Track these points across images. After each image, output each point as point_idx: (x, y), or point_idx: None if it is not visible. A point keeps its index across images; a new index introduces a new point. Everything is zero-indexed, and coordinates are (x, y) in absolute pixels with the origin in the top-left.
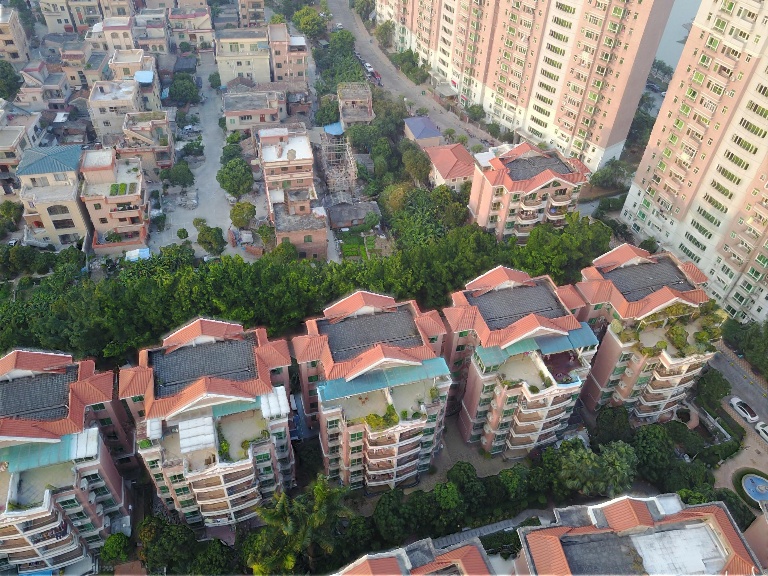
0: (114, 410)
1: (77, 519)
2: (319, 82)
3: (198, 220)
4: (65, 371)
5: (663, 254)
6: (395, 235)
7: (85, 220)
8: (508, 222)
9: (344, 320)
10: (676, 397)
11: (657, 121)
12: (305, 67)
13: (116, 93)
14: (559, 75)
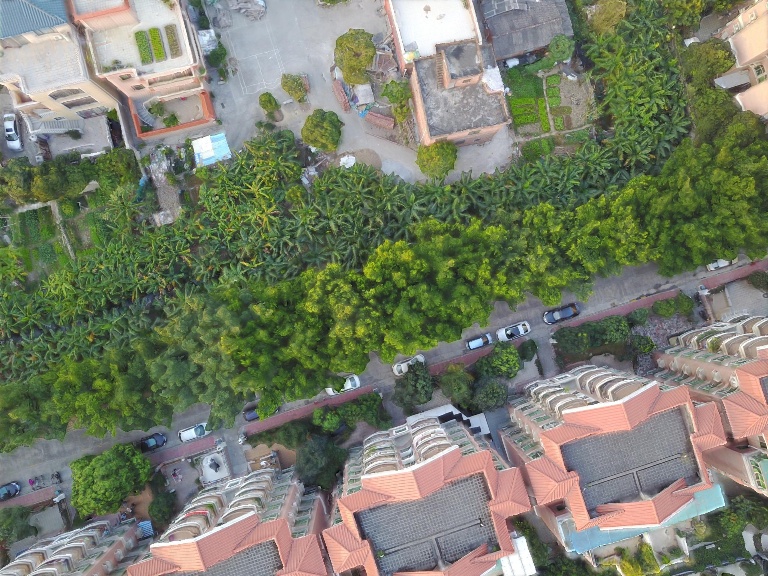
0: None
1: None
2: None
3: (290, 84)
4: None
5: None
6: (596, 84)
7: (110, 91)
8: None
9: None
10: None
11: None
12: None
13: None
14: None
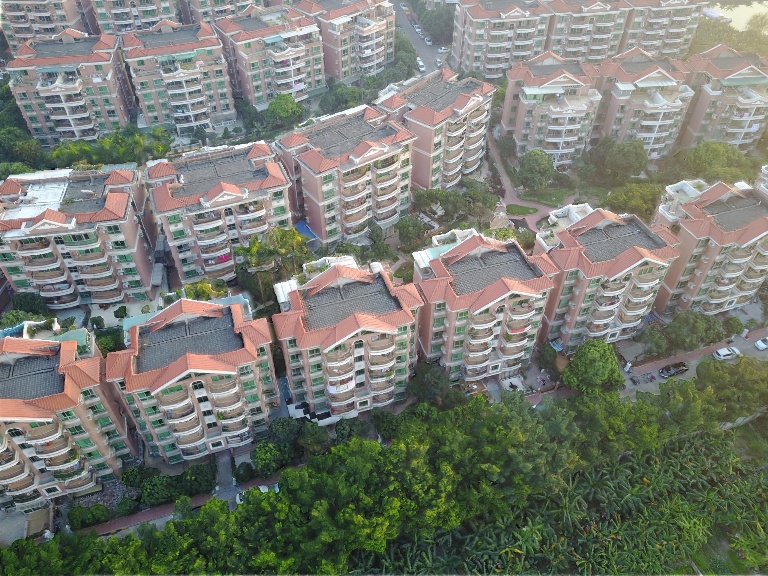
0: None
1: None
2: None
3: None
4: None
5: None
6: None
7: None
8: None
9: None
10: None
11: None
12: None
13: None
14: None
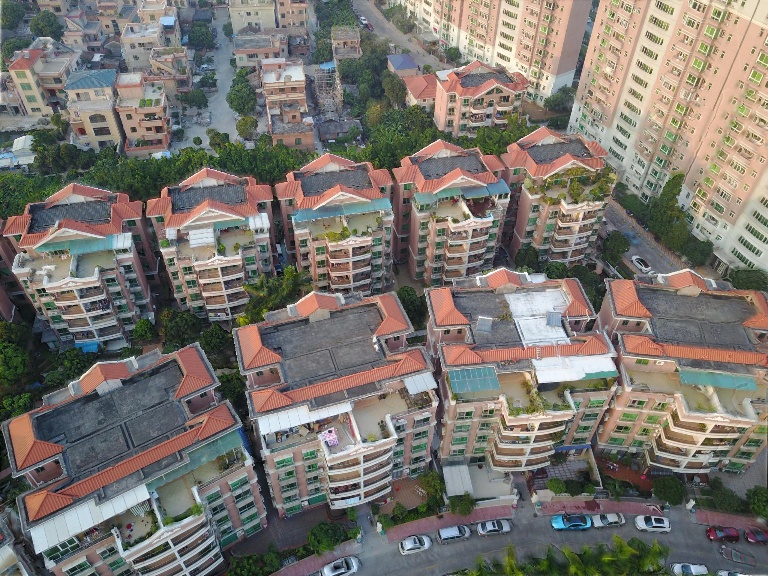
0: (143, 228)
1: (117, 298)
2: (318, 30)
3: (210, 129)
4: (108, 200)
5: (574, 136)
6: None
7: (119, 129)
8: (461, 125)
9: (315, 174)
10: (580, 246)
11: (590, 43)
12: (306, 17)
13: (144, 33)
14: (517, 13)
